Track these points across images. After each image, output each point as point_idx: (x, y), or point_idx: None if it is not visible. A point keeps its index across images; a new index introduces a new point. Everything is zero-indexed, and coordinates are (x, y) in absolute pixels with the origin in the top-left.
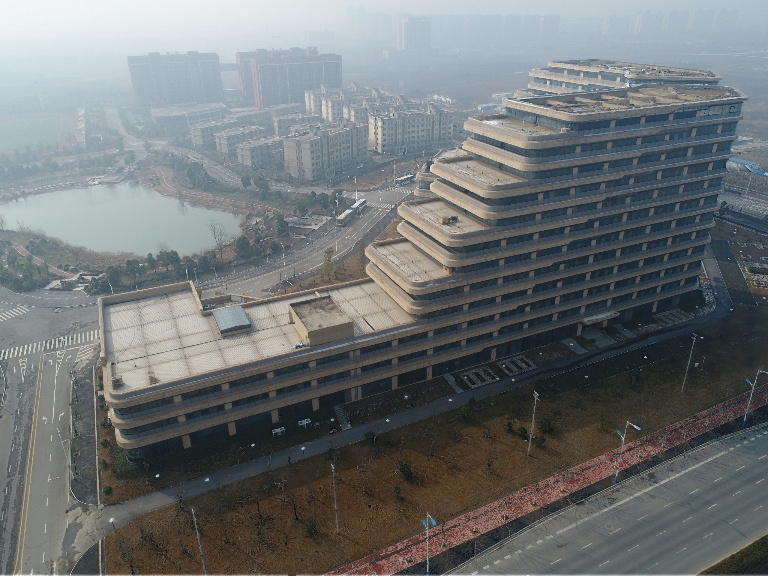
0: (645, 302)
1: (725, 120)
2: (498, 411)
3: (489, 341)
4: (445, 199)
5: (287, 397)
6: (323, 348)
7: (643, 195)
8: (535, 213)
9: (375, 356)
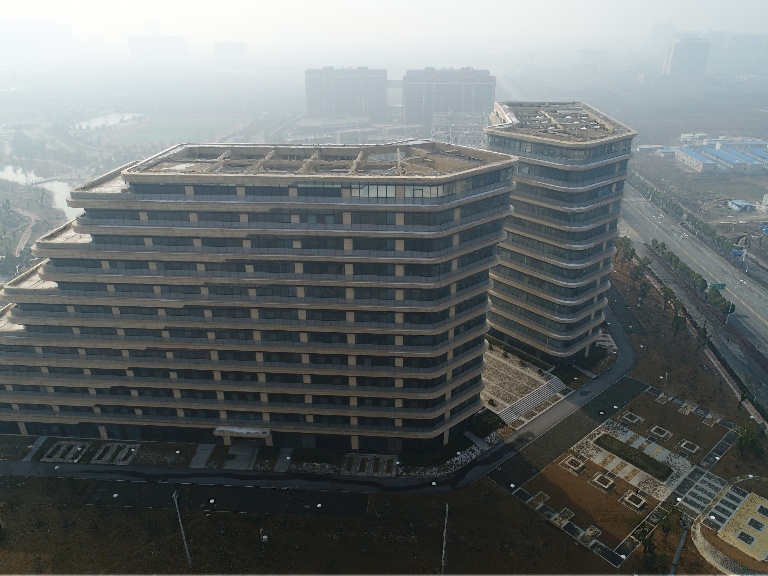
0: (327, 432)
1: (399, 207)
2: (6, 495)
3: (90, 416)
4: None
5: None
6: None
7: (279, 290)
8: (102, 283)
9: None
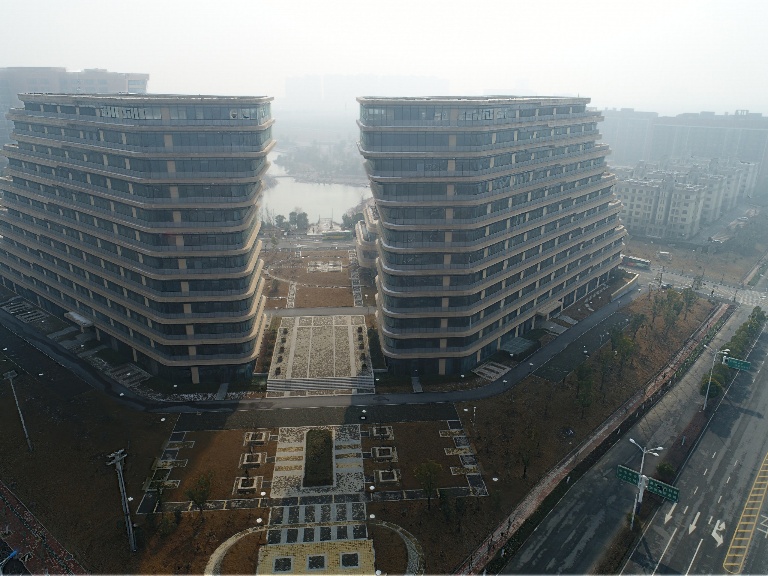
0: (117, 336)
1: (118, 126)
2: None
3: None
4: None
5: None
6: None
7: (84, 197)
8: (23, 179)
9: None
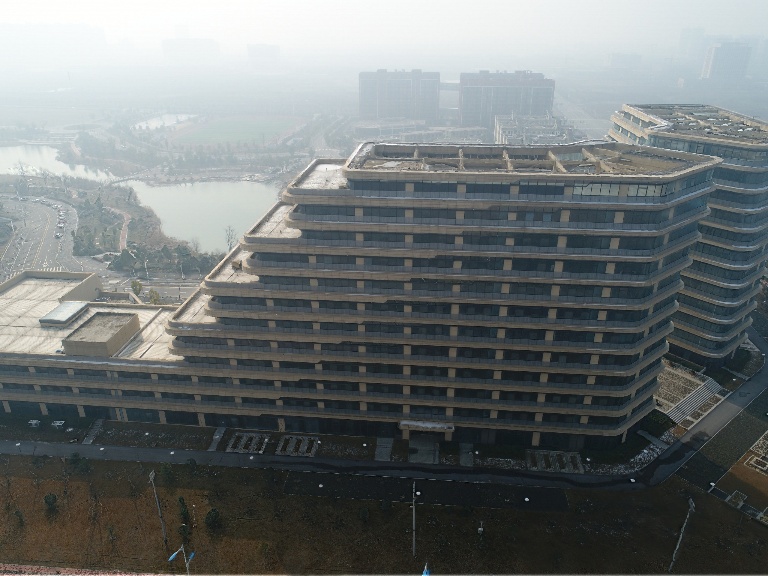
0: (510, 428)
1: (623, 206)
2: (207, 483)
3: (272, 408)
4: None
5: (51, 395)
6: (78, 360)
7: (483, 286)
8: (306, 277)
9: (132, 383)
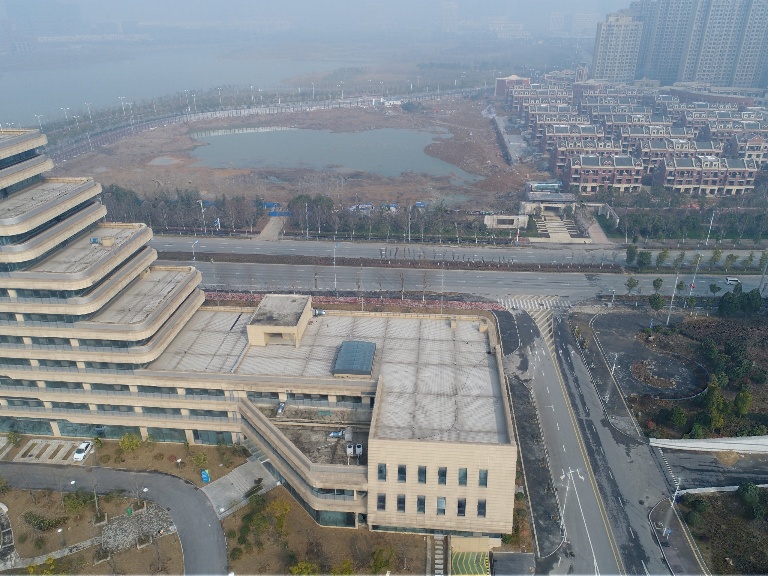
0: None
1: None
2: None
3: None
4: (31, 262)
5: None
6: None
7: None
8: None
9: None
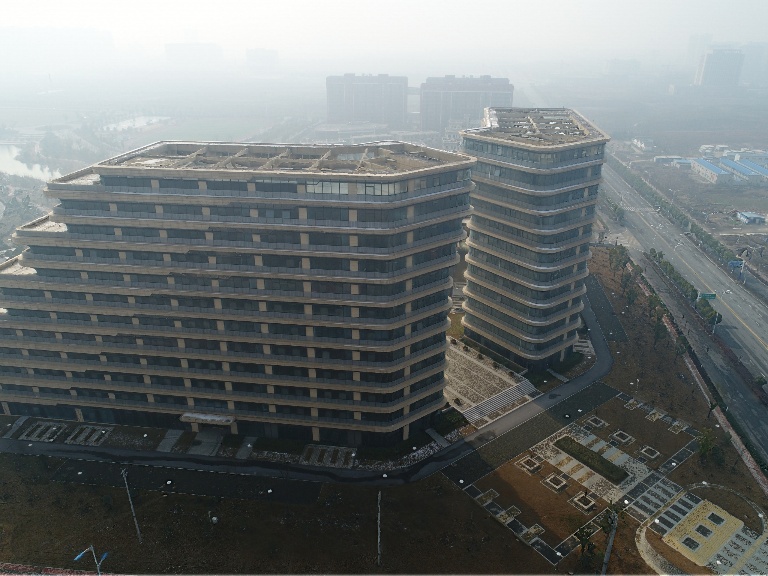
0: (288, 422)
1: (352, 204)
2: None
3: (67, 398)
4: None
5: None
6: None
7: (240, 282)
8: (76, 270)
9: None
